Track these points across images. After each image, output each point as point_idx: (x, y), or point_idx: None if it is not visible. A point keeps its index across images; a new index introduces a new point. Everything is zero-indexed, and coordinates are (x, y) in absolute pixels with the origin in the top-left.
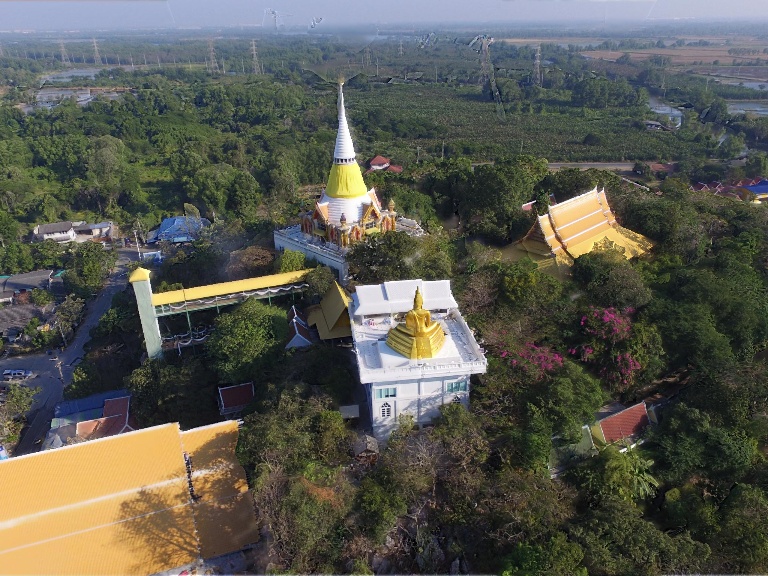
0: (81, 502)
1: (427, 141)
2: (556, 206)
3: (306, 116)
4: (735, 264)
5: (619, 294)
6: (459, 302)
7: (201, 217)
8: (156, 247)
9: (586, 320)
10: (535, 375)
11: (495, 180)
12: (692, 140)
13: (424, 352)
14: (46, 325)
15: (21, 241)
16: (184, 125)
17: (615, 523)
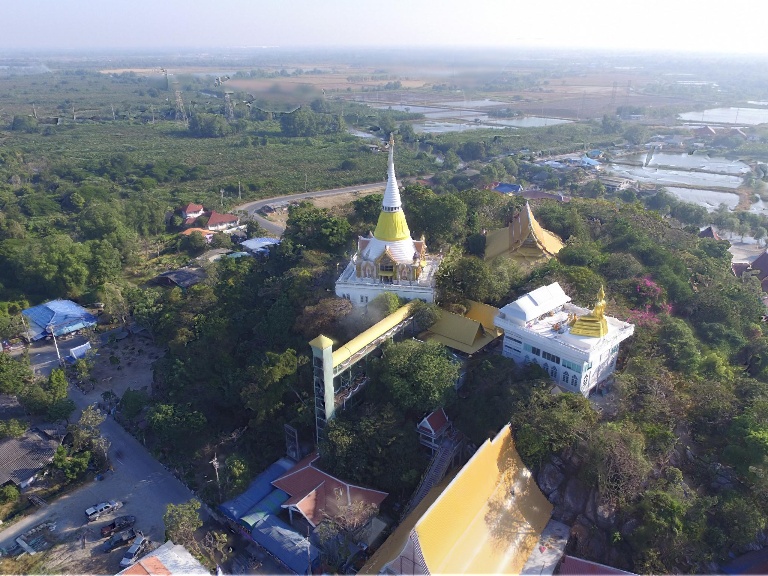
0: (466, 529)
1: (199, 183)
2: None
3: (26, 170)
4: (640, 238)
5: (631, 269)
6: None
7: None
8: (46, 343)
9: (640, 288)
10: (656, 326)
11: (445, 208)
12: (416, 158)
13: (605, 330)
14: None
15: None
16: None
17: (761, 388)
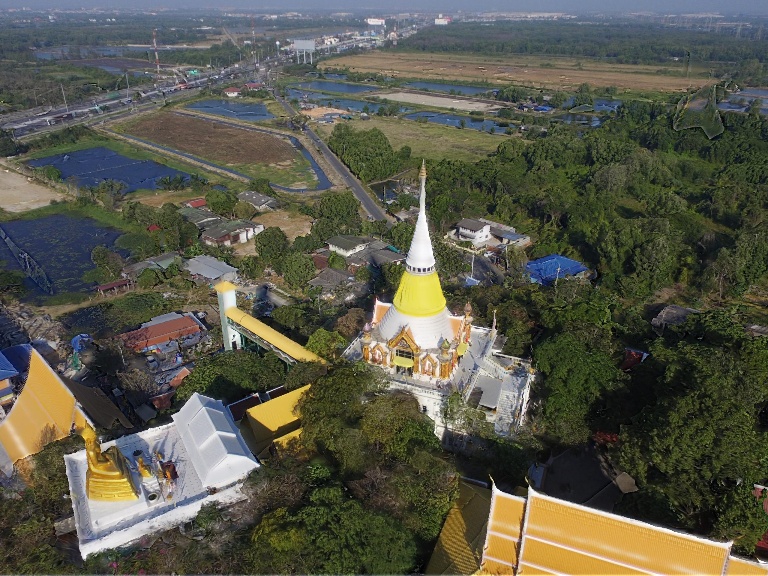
0: None
1: None
2: (554, 500)
3: None
4: None
5: None
6: None
7: (595, 267)
8: None
9: None
10: None
11: None
12: None
13: None
14: (334, 296)
15: (443, 226)
16: None
17: None
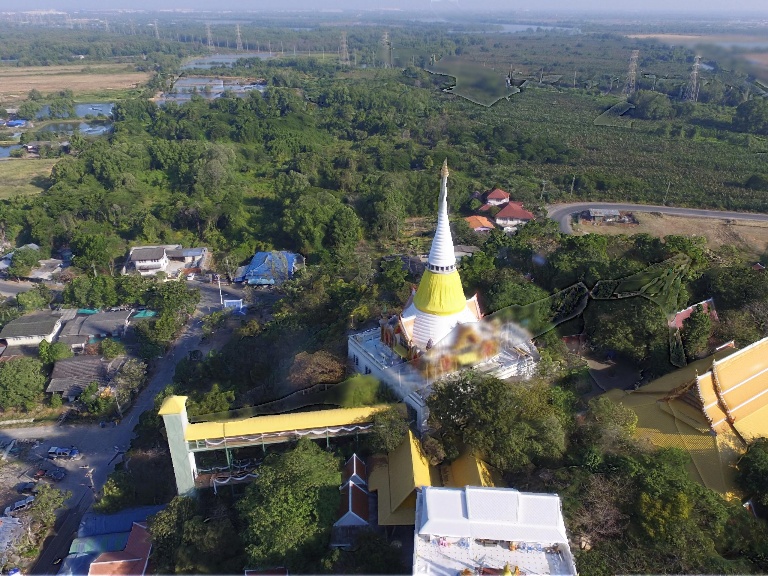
0: None
1: (555, 168)
2: (724, 360)
3: (427, 127)
4: None
5: None
6: (570, 520)
7: (296, 251)
8: (243, 287)
9: None
10: None
11: None
12: None
13: None
14: (107, 387)
15: (113, 267)
16: (301, 130)
17: None
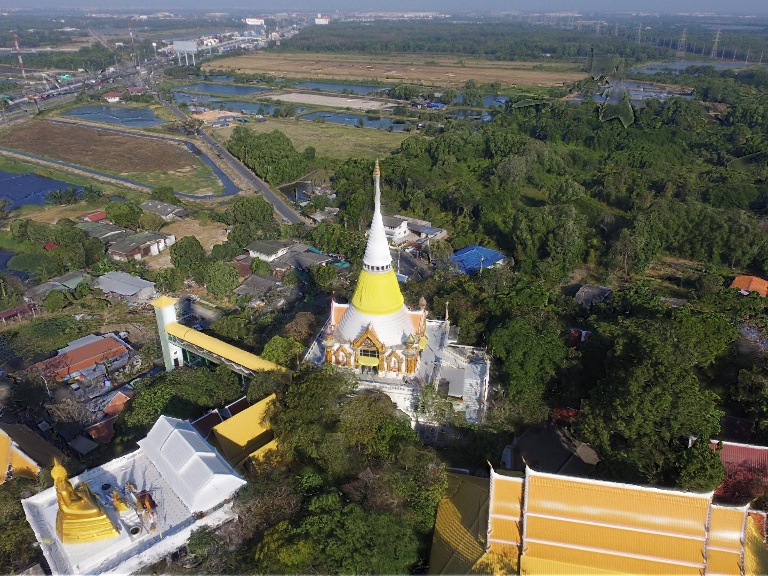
0: None
1: None
2: (551, 476)
3: None
4: None
5: None
6: None
7: (512, 255)
8: None
9: None
10: None
11: (632, 376)
12: None
13: None
14: (264, 302)
15: (362, 224)
16: (660, 145)
17: None
